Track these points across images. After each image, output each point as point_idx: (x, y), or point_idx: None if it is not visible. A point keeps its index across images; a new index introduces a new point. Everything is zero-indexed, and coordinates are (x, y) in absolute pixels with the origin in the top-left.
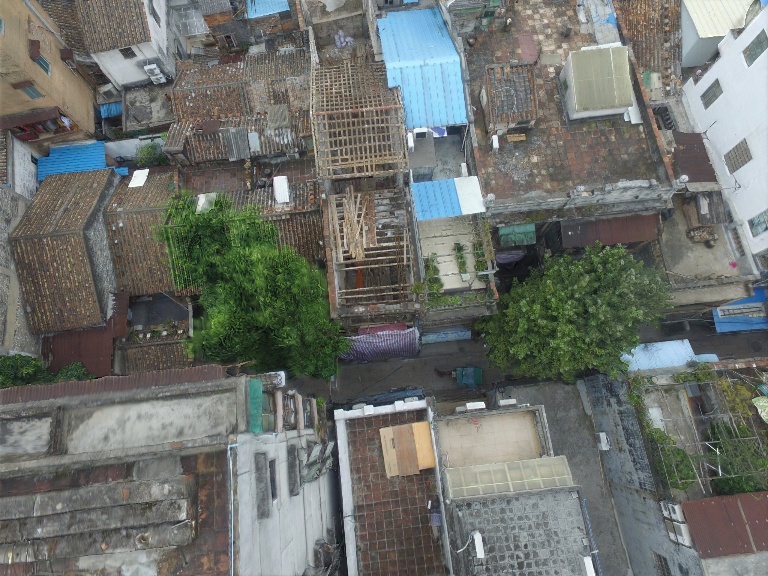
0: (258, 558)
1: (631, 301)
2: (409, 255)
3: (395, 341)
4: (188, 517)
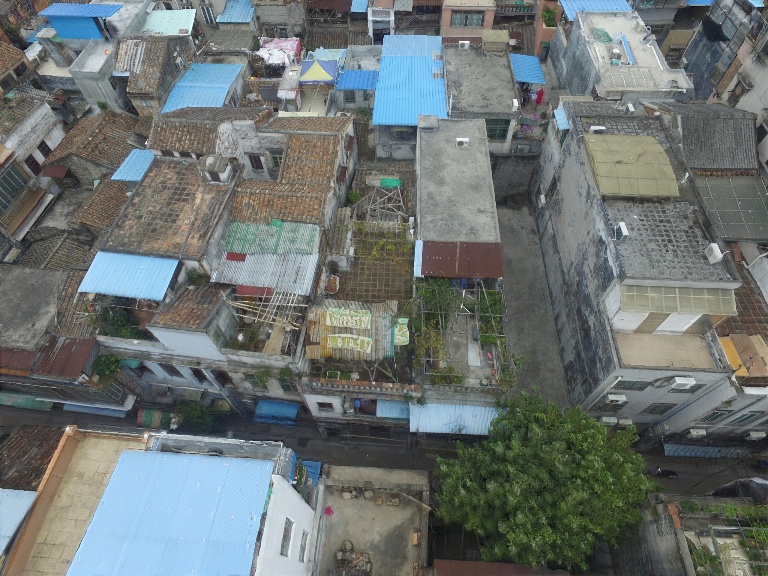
0: None
1: None
2: None
3: None
4: None
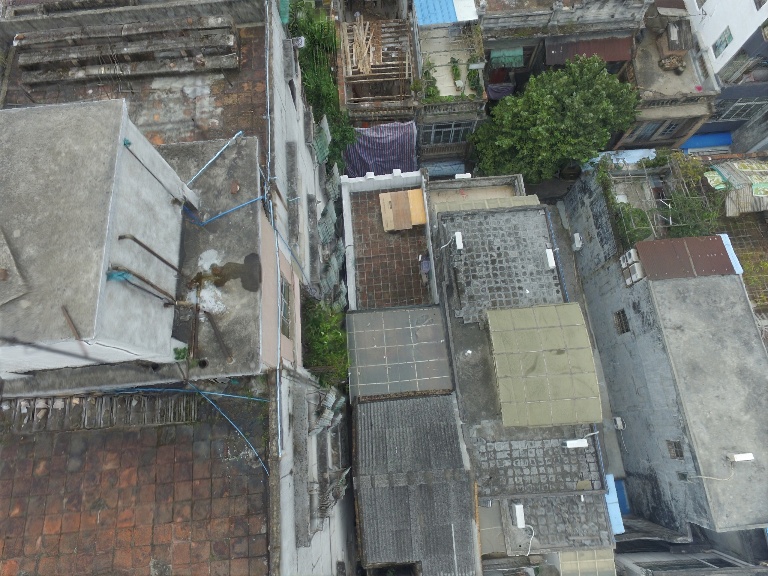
0: (284, 99)
1: (603, 99)
2: (410, 72)
3: (395, 138)
4: (234, 46)
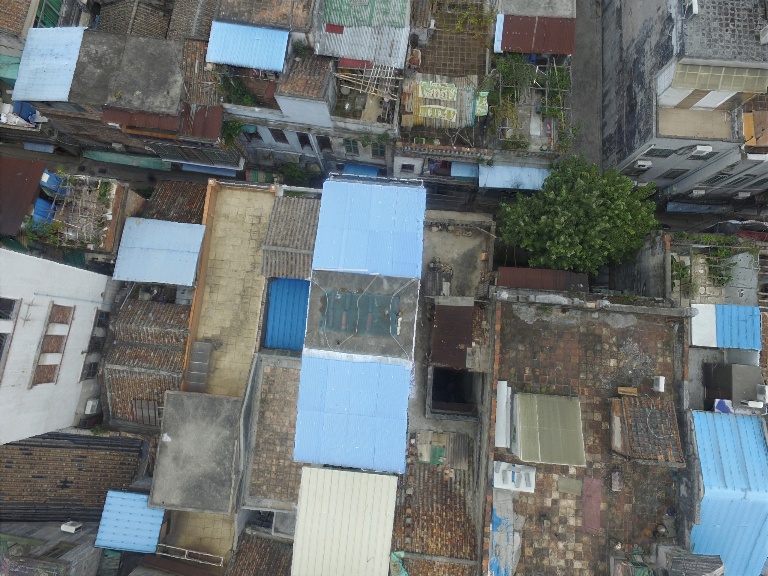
0: None
1: None
2: None
3: None
4: None
